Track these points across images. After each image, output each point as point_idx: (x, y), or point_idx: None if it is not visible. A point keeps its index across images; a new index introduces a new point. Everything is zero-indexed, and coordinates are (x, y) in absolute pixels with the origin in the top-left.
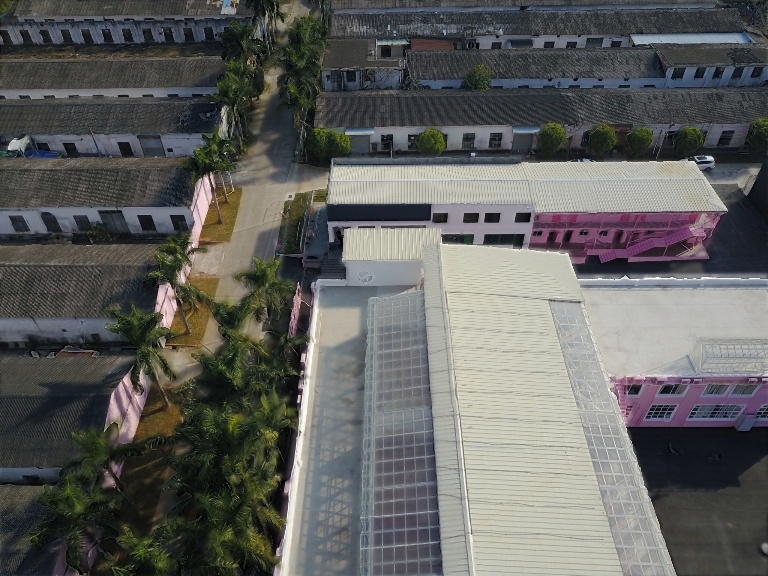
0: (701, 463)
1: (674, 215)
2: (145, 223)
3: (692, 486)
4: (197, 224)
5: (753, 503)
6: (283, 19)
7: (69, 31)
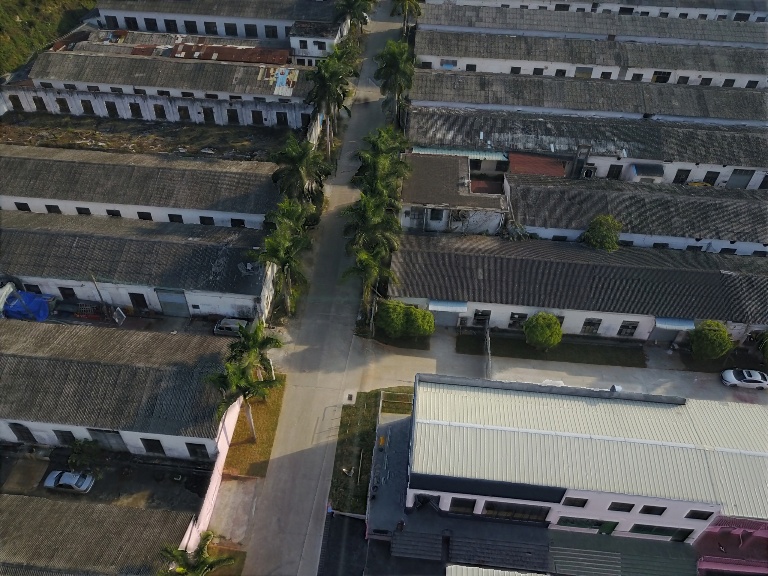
0: None
1: None
2: (150, 445)
3: None
4: (222, 451)
5: None
6: (350, 114)
7: (91, 102)
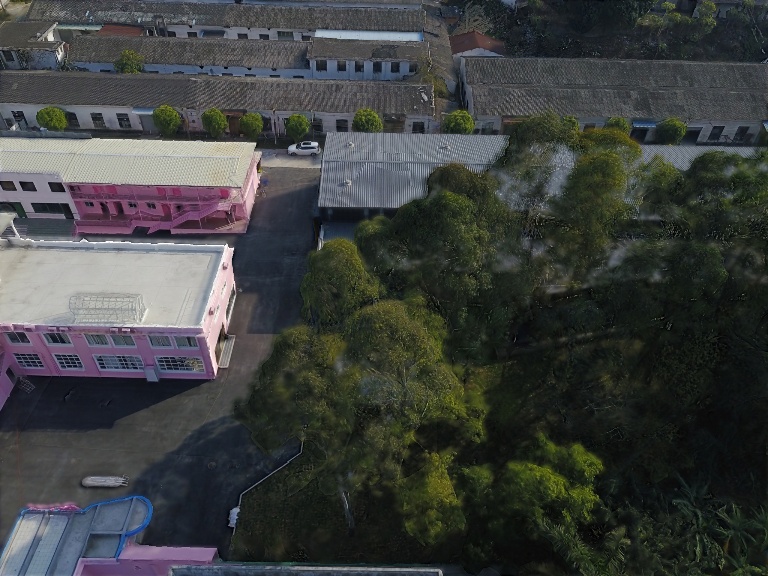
0: (90, 408)
1: (197, 189)
2: None
3: (66, 427)
4: None
5: (110, 442)
6: None
7: None
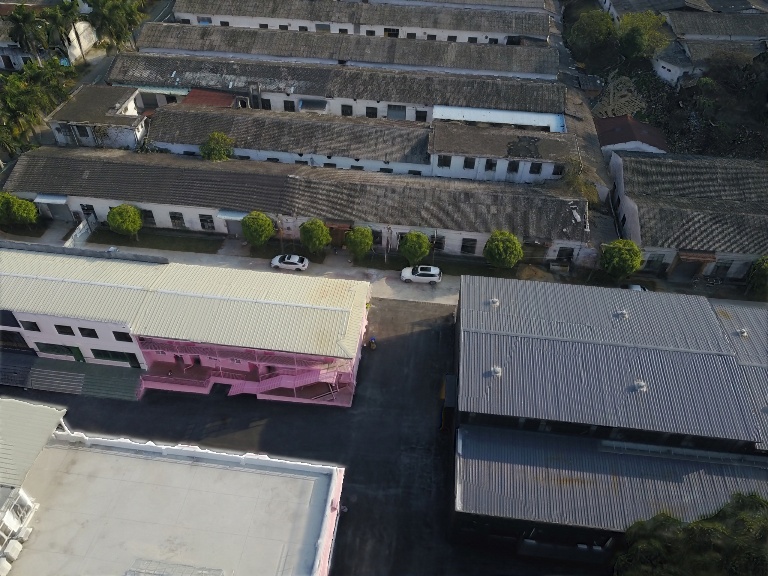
0: None
1: (295, 354)
2: None
3: None
4: None
5: None
6: (66, 55)
7: None
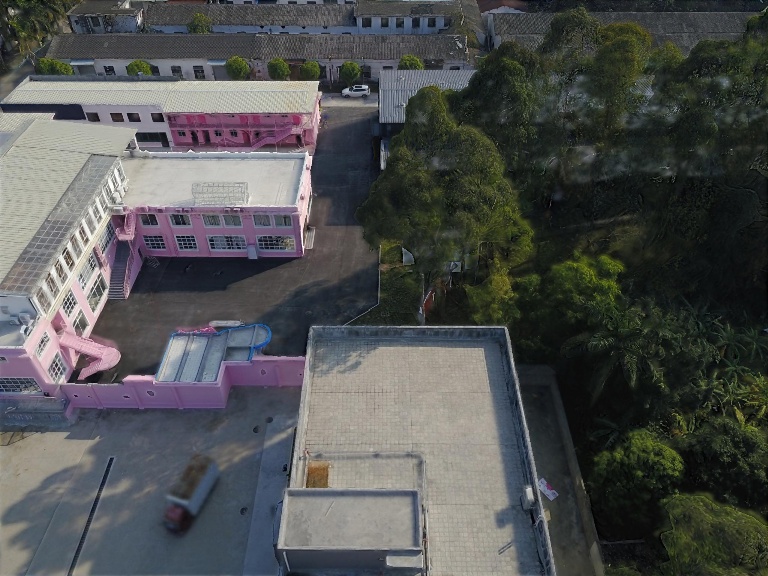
0: (206, 277)
1: (274, 116)
2: None
3: (190, 290)
4: None
5: (226, 299)
6: None
7: None
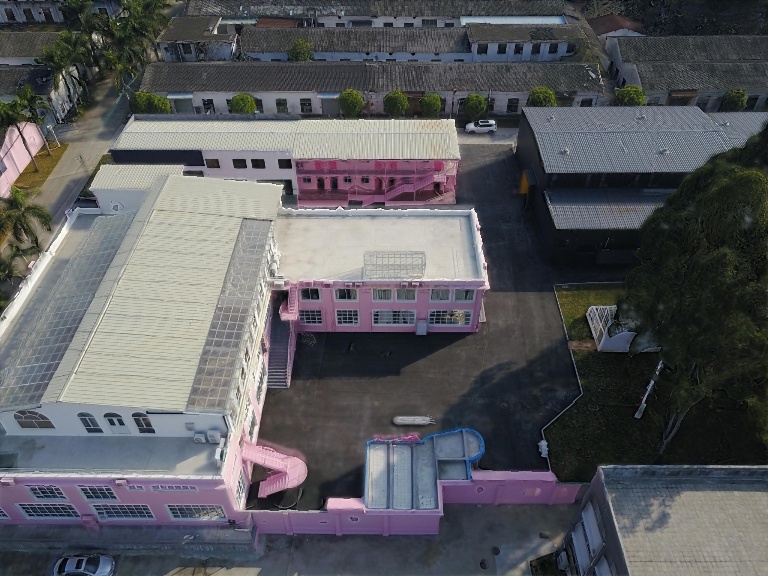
0: (373, 358)
1: (416, 163)
2: None
3: (359, 375)
4: (11, 171)
5: (403, 388)
6: None
7: None
